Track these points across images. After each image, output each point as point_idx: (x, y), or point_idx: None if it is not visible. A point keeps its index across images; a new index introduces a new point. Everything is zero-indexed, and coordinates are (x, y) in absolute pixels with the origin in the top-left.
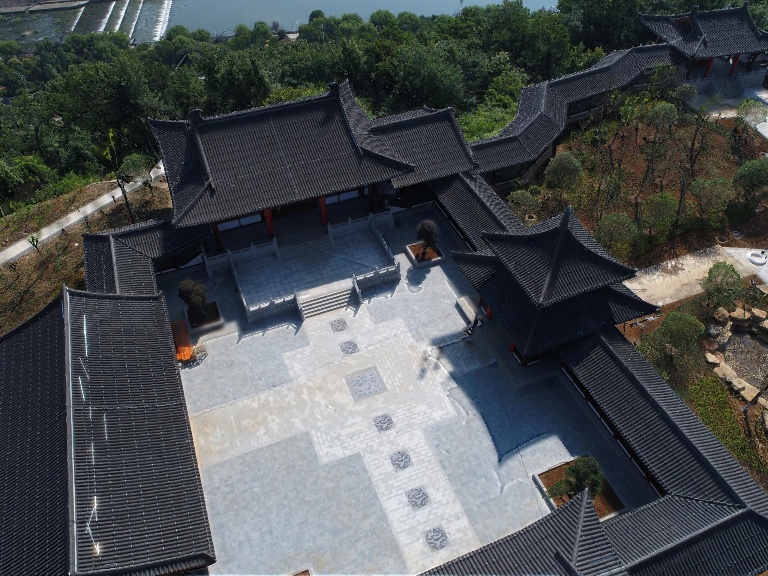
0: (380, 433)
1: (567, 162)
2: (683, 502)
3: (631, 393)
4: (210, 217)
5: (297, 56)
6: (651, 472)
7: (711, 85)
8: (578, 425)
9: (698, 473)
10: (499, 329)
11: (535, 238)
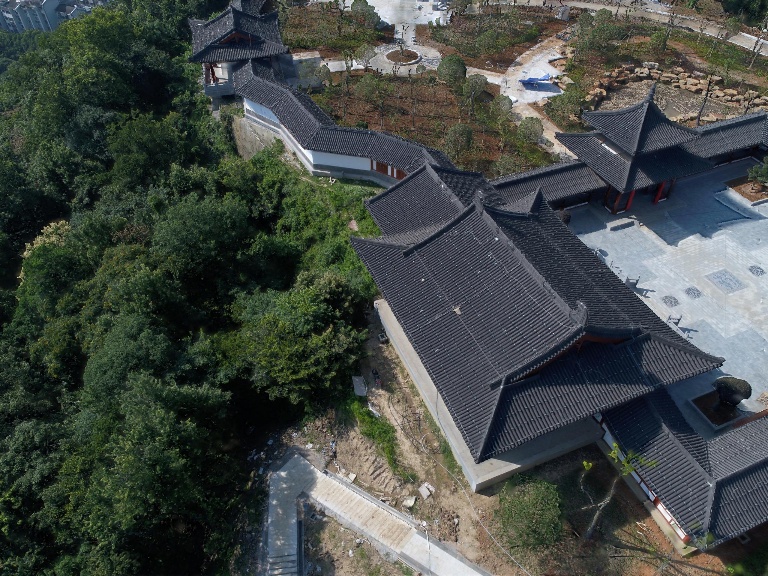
0: (767, 272)
1: (469, 128)
2: (767, 137)
3: (707, 138)
4: (679, 338)
5: (135, 349)
6: (752, 145)
7: (284, 70)
8: (699, 185)
9: (750, 127)
10: (636, 207)
11: (644, 123)
